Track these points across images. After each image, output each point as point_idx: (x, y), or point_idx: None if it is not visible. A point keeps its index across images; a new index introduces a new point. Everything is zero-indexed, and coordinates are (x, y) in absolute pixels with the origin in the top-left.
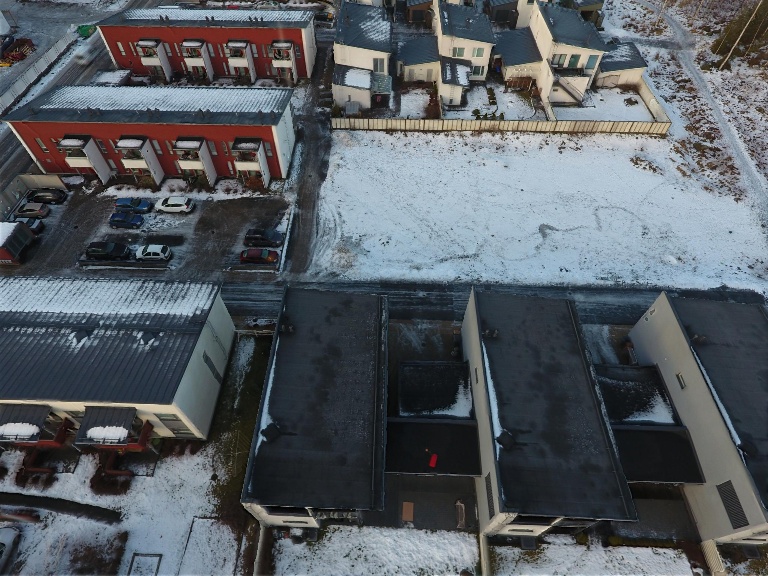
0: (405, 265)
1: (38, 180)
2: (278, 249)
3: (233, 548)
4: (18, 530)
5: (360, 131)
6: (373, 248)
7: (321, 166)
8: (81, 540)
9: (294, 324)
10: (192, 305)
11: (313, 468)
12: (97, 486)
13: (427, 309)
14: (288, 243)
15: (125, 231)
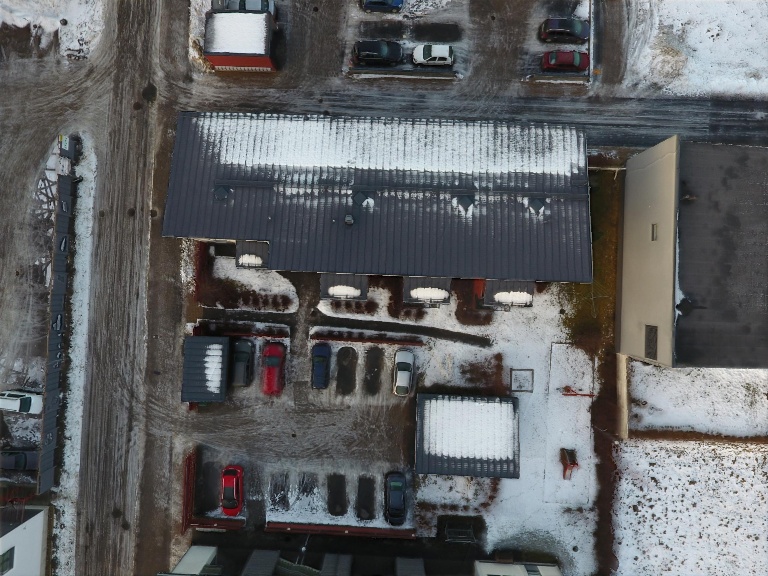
0: (739, 72)
1: None
2: (583, 47)
3: (589, 365)
4: (412, 352)
5: None
6: (699, 45)
7: None
8: (464, 358)
9: (691, 190)
10: (565, 161)
11: (724, 337)
12: (463, 319)
13: (765, 137)
14: (594, 37)
15: (383, 17)
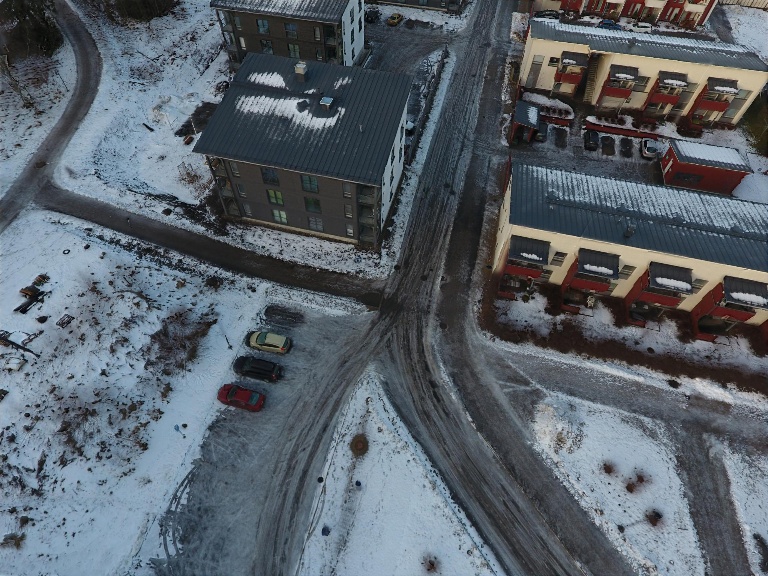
0: None
1: (544, 5)
2: None
3: None
4: None
5: (744, 7)
6: None
7: (724, 23)
8: None
9: None
10: (739, 49)
11: None
12: (683, 133)
13: None
14: None
15: None
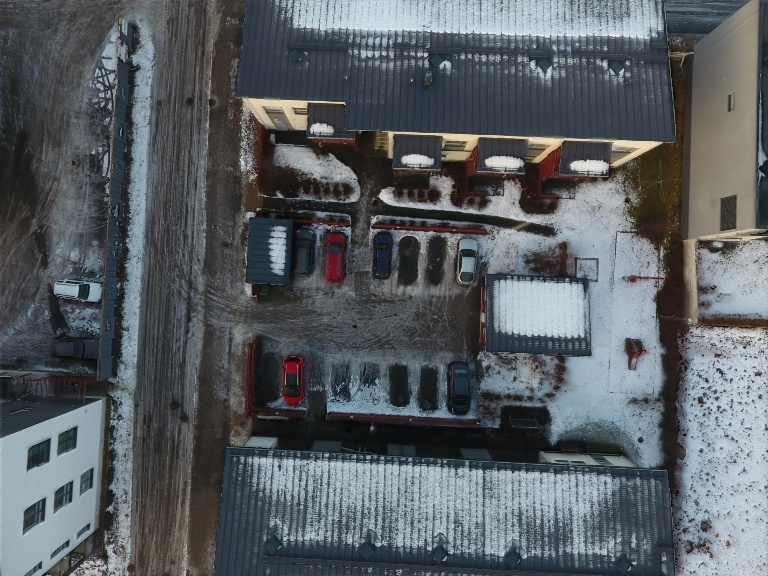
0: None
1: None
2: None
3: (655, 254)
4: None
5: None
6: None
7: None
8: (528, 248)
9: None
10: (644, 25)
11: None
12: (528, 207)
13: None
14: None
15: None
